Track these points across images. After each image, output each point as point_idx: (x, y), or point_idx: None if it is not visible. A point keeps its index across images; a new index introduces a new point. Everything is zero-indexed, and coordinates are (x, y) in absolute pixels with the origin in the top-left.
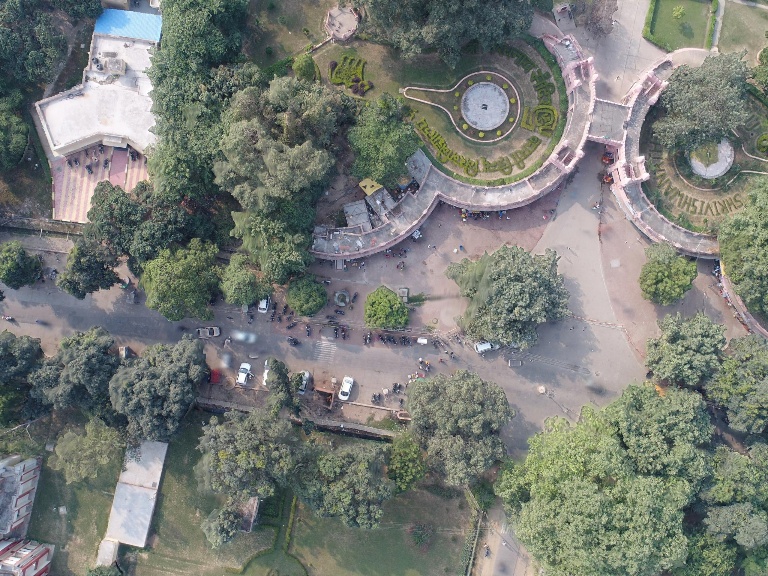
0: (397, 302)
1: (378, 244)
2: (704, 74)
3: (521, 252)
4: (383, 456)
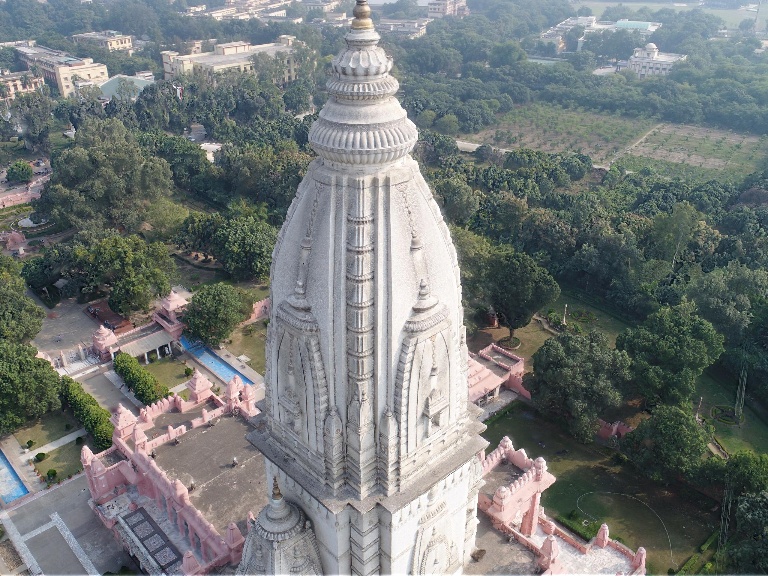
0: (16, 168)
1: (44, 179)
2: None
3: None
4: None
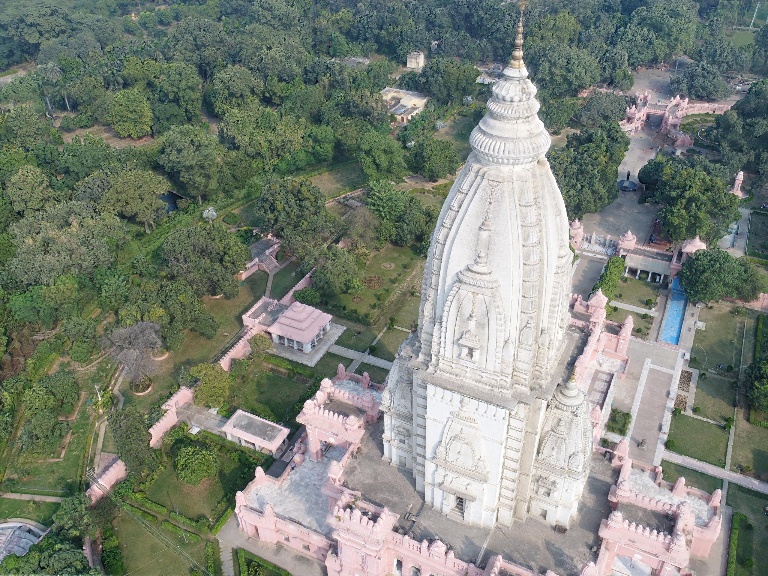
0: (760, 83)
1: None
2: (611, 105)
3: (698, 88)
4: (759, 50)
